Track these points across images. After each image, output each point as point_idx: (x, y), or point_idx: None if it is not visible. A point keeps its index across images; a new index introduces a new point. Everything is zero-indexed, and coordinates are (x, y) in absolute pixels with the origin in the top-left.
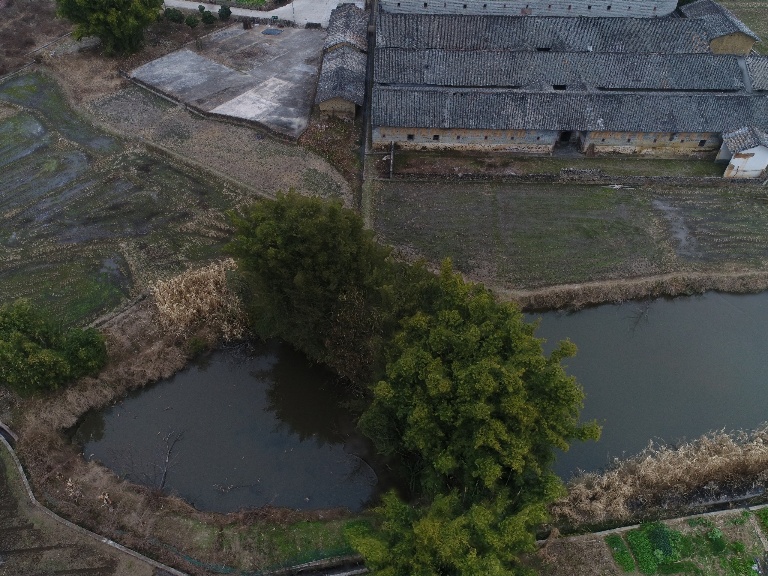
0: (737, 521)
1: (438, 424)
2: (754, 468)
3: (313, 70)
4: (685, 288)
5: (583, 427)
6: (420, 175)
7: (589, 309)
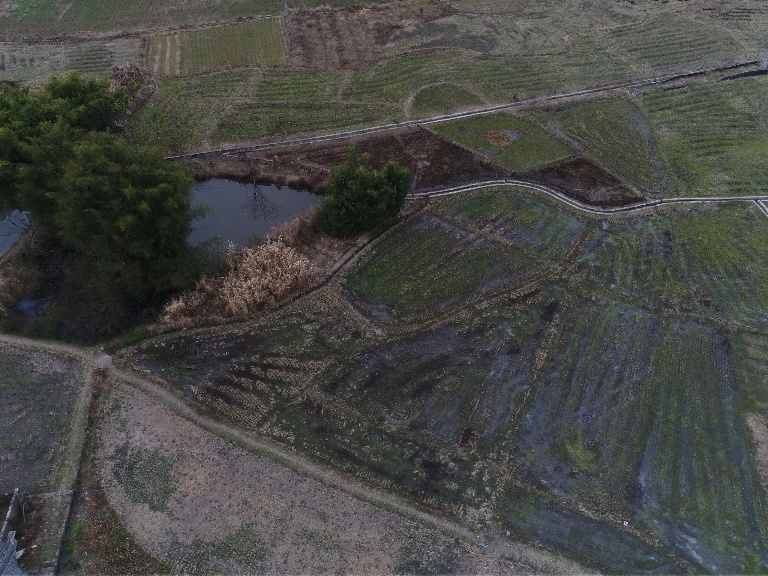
0: None
1: None
2: None
3: None
4: None
5: None
6: None
7: None
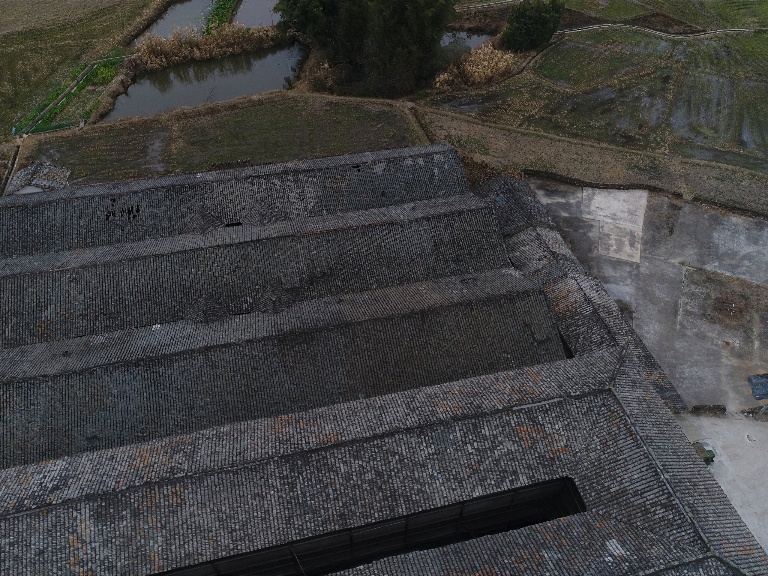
0: None
1: None
2: None
3: None
4: None
5: None
6: None
7: None
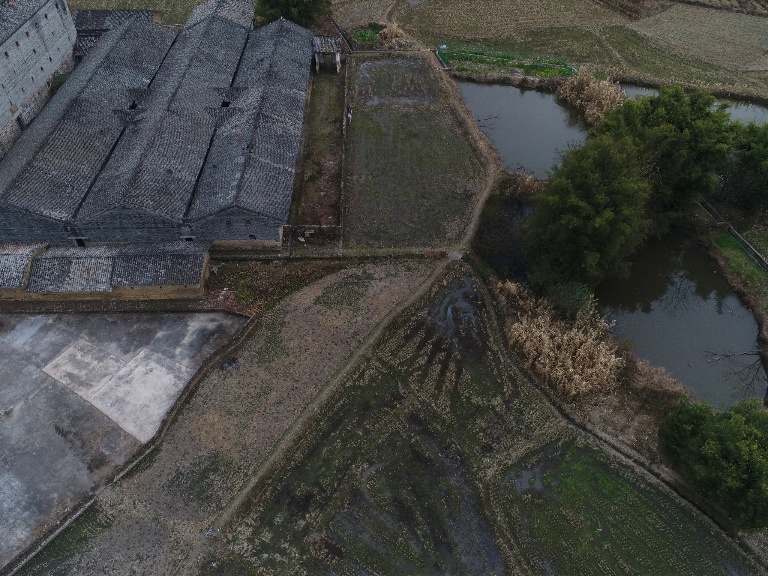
0: None
1: None
2: None
3: (39, 320)
4: None
5: None
6: None
7: None
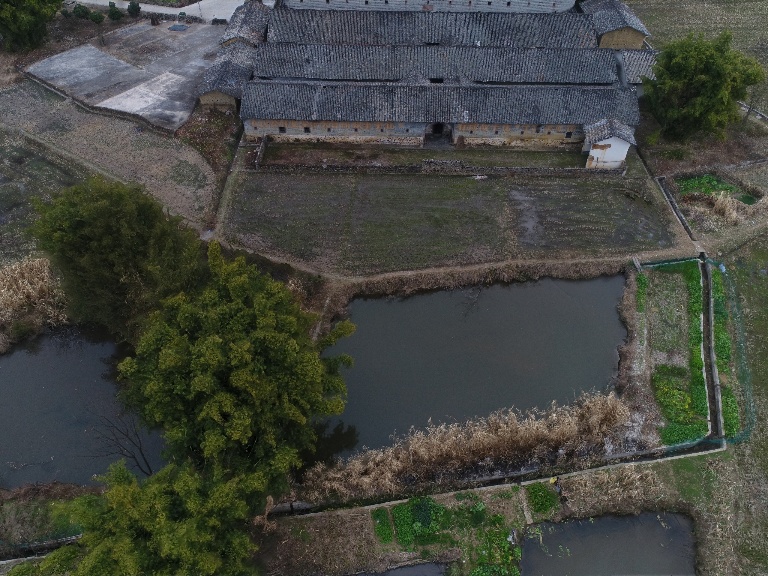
0: (503, 495)
1: (180, 398)
2: (528, 445)
3: (209, 65)
4: (519, 275)
5: (327, 402)
6: (285, 166)
7: (423, 295)
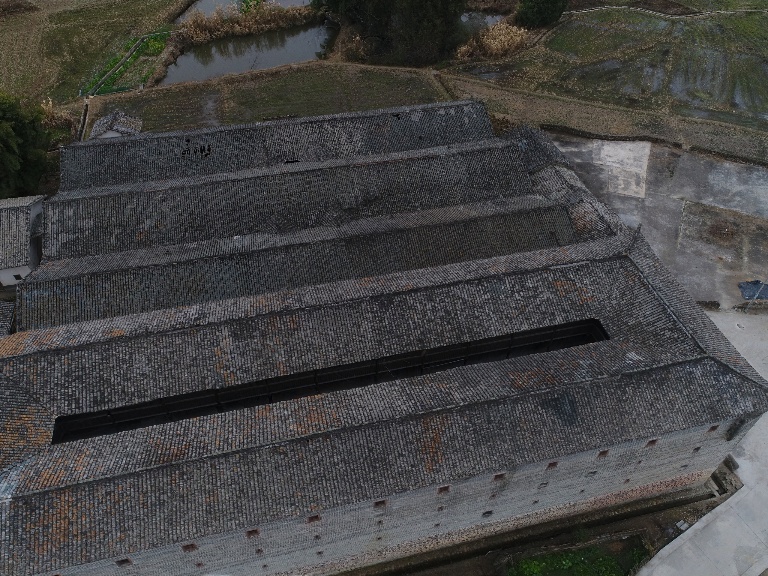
0: None
1: None
2: None
3: None
4: None
5: None
6: None
7: None
